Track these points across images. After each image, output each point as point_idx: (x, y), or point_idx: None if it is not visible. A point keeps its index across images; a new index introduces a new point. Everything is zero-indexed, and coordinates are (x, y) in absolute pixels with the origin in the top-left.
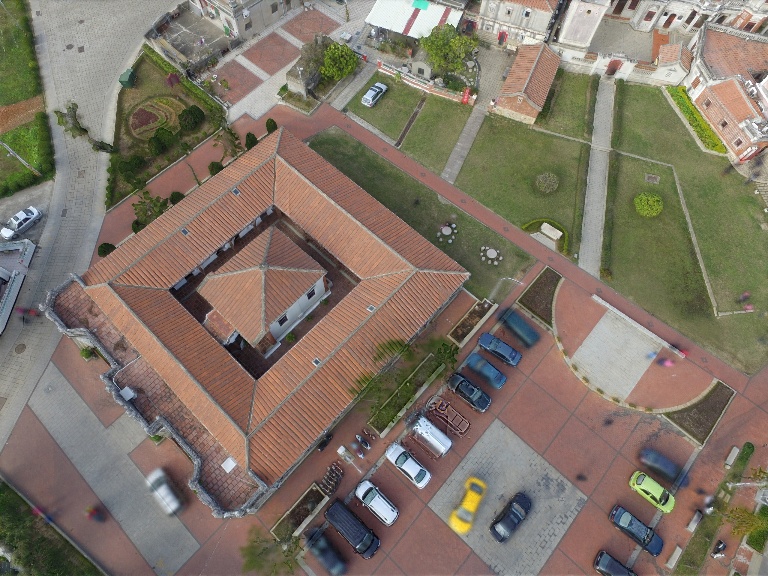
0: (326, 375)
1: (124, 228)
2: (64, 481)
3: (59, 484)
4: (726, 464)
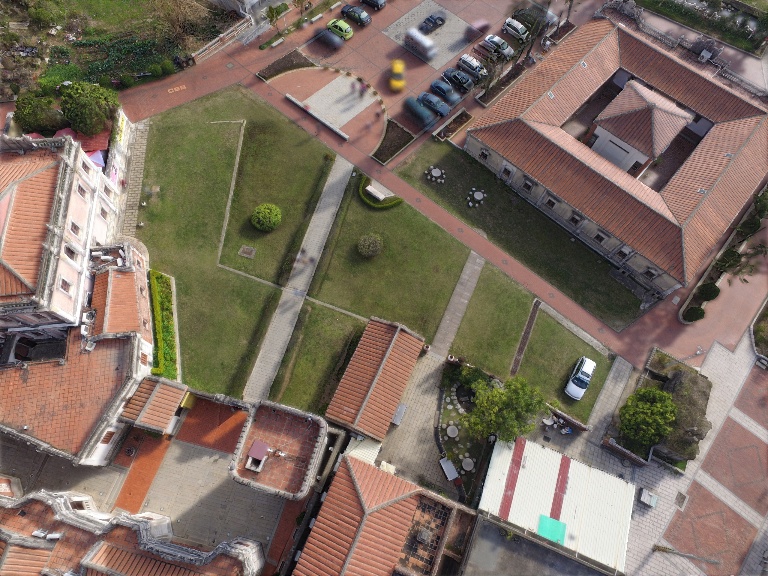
0: None
1: None
2: None
3: None
4: (284, 40)
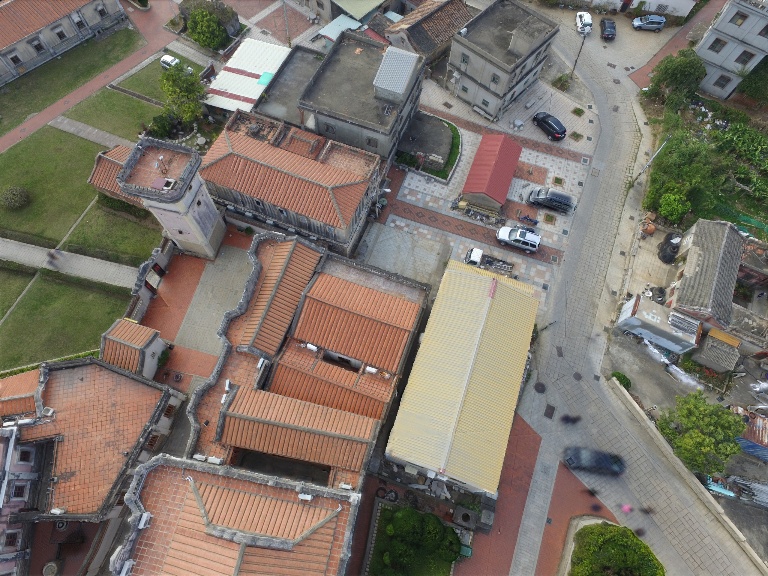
0: None
1: None
2: None
3: None
4: None
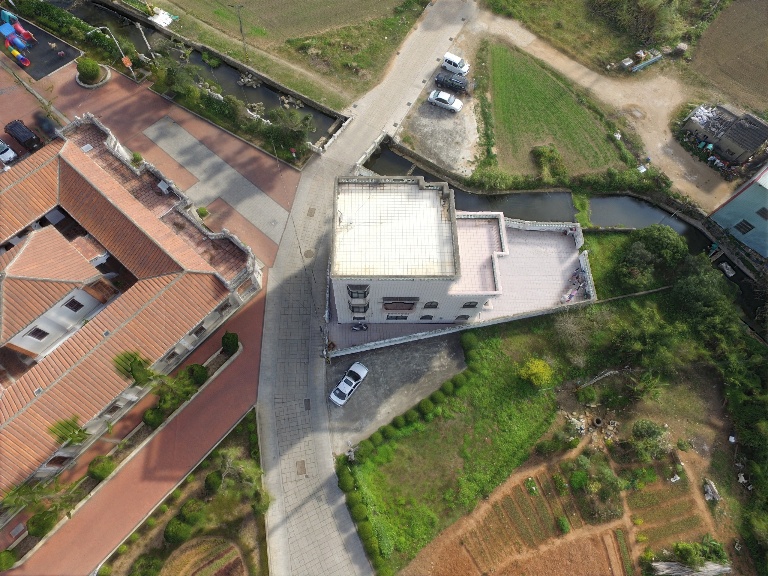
0: None
1: (230, 385)
2: (246, 165)
3: (249, 163)
4: None
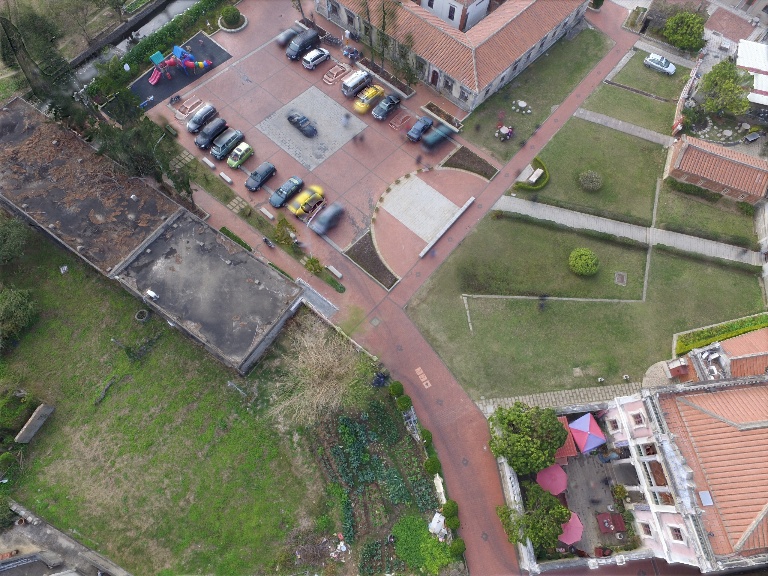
0: (392, 8)
1: None
2: None
3: None
4: None
